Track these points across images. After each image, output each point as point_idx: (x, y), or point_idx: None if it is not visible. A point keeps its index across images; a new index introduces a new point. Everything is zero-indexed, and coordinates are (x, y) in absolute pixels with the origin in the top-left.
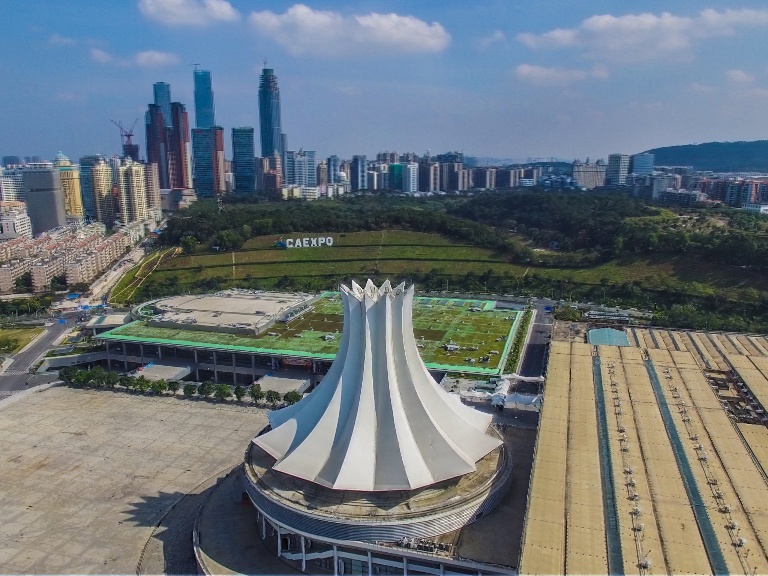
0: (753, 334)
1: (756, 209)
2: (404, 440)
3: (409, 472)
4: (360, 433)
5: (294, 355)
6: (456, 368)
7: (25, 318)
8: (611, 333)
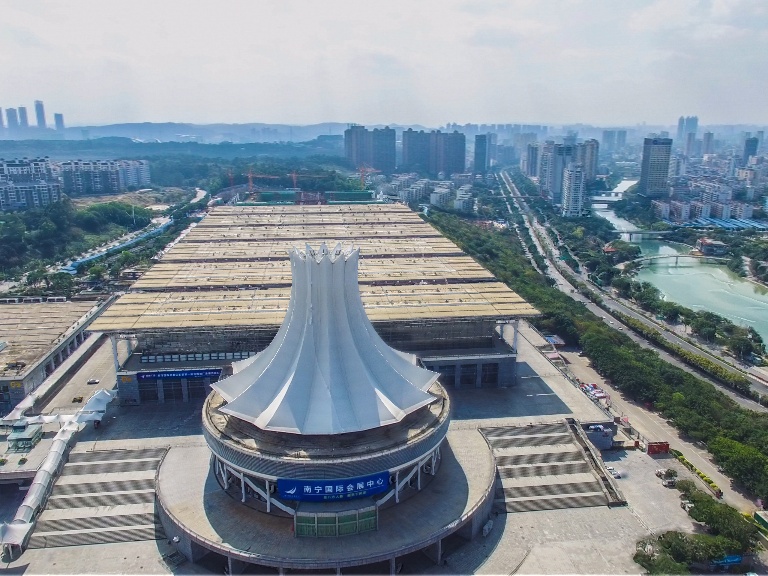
0: None
1: None
2: None
3: None
4: None
5: None
6: None
7: None
8: None
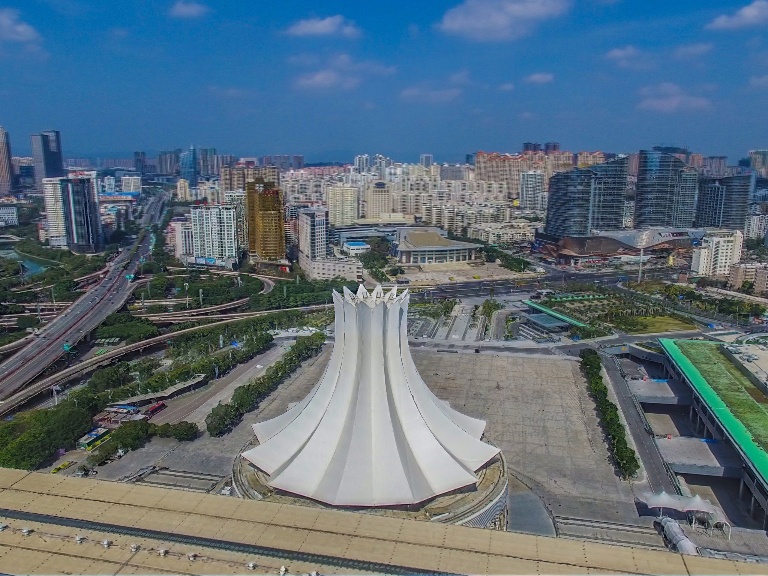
0: None
1: None
2: (298, 431)
3: (261, 447)
4: (301, 408)
5: (726, 429)
6: None
7: (719, 317)
8: None
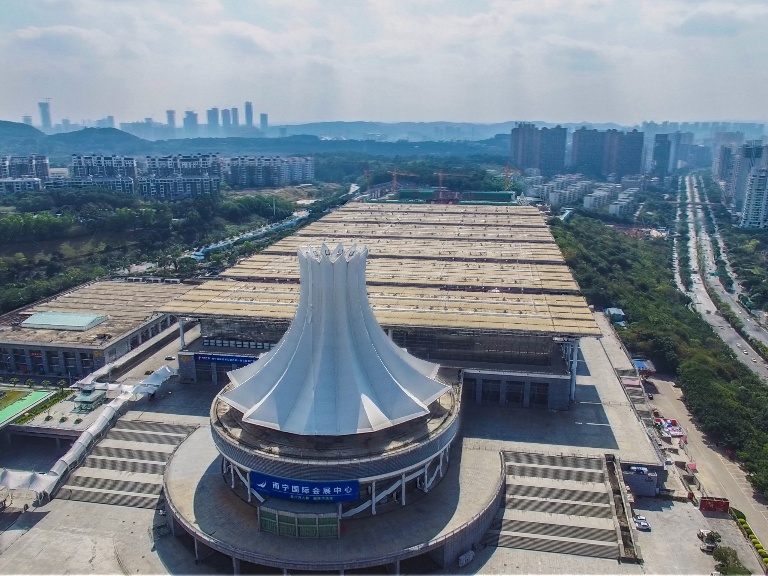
0: (90, 282)
1: None
2: None
3: None
4: None
5: None
6: (10, 414)
7: None
8: (56, 314)
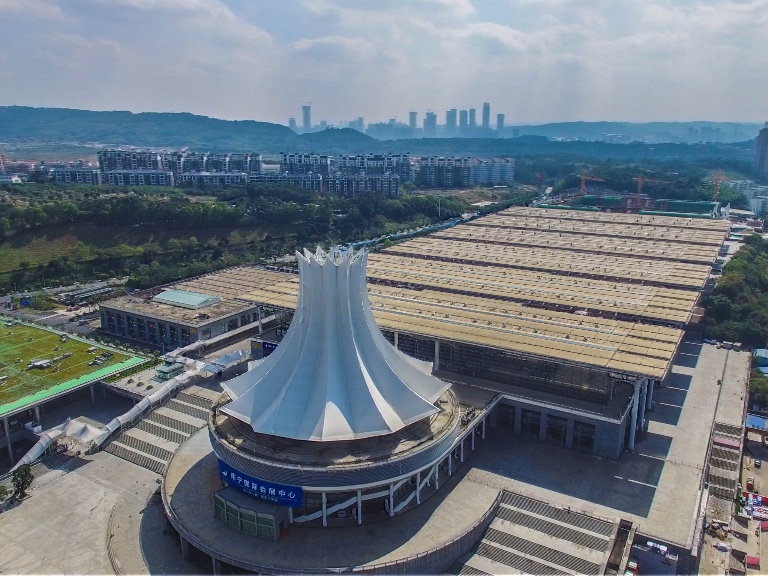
0: (234, 267)
1: (7, 180)
2: None
3: None
4: None
5: None
6: (104, 373)
7: None
8: (181, 292)
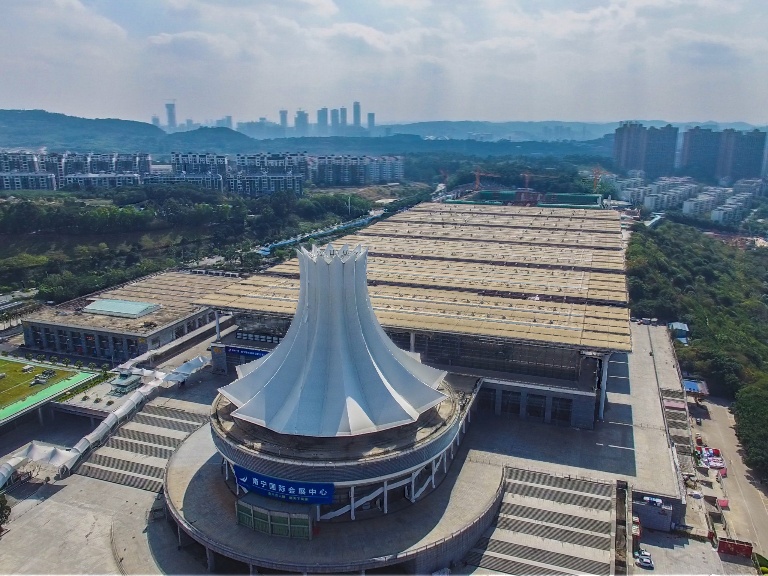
0: (158, 273)
1: None
2: None
3: None
4: None
5: None
6: (53, 391)
7: None
8: (115, 301)
